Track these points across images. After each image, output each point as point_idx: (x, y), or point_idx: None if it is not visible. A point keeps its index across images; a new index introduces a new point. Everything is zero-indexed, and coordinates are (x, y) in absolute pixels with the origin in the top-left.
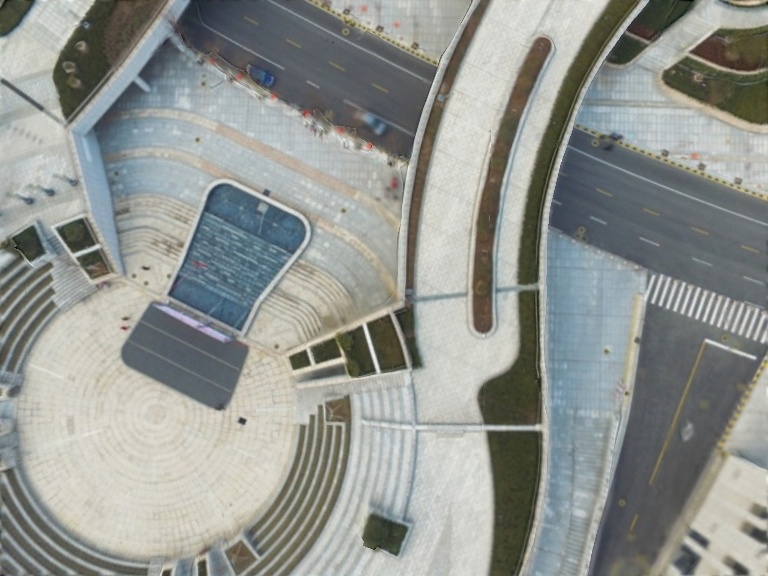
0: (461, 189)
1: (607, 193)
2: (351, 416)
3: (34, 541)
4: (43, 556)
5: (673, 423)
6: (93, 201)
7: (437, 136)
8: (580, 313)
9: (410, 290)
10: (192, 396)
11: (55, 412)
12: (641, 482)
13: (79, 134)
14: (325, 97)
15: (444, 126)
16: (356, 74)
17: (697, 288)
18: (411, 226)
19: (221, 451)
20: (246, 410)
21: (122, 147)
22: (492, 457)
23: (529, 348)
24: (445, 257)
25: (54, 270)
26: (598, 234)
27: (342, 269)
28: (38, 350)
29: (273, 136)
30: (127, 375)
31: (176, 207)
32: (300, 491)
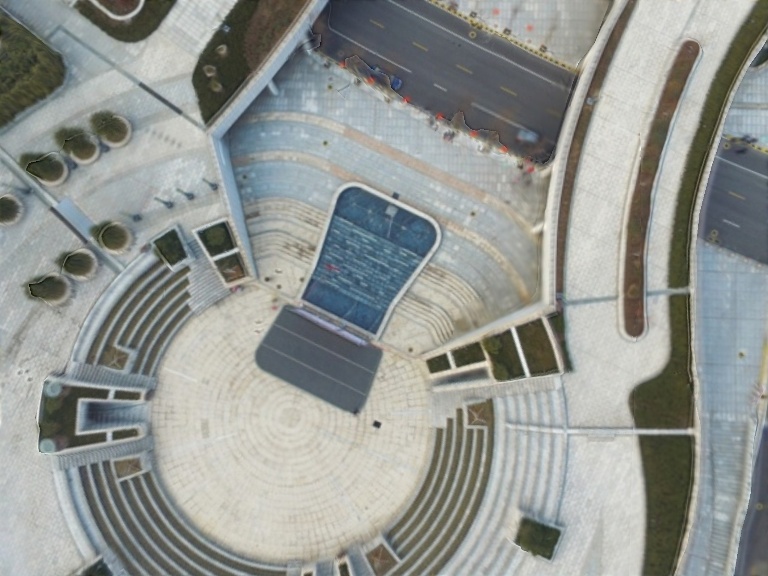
0: (610, 193)
1: (740, 196)
2: (494, 420)
3: (173, 544)
4: (183, 559)
5: None
6: (232, 205)
7: (585, 139)
8: (714, 316)
9: (560, 294)
10: (327, 399)
11: (189, 415)
12: None
13: (217, 138)
14: (453, 100)
15: (592, 129)
16: (484, 77)
17: None
18: (560, 230)
19: (356, 454)
20: (381, 413)
21: (250, 150)
22: (644, 461)
23: (681, 352)
24: (594, 261)
25: (191, 274)
26: (731, 237)
27: (472, 272)
28: (172, 353)
29: (401, 139)
30: (261, 378)
31: (306, 210)
32: (440, 494)
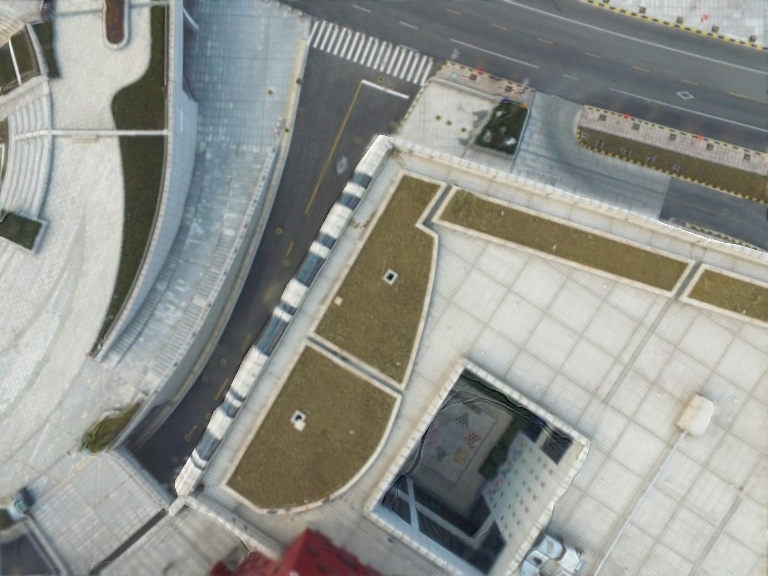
0: None
1: None
2: (8, 136)
3: None
4: None
5: (329, 157)
6: None
7: None
8: (247, 57)
9: (48, 5)
10: None
11: None
12: (298, 212)
13: None
14: None
15: None
16: None
17: (356, 33)
18: None
19: None
20: None
21: None
22: (123, 160)
23: (158, 58)
24: None
25: None
26: None
27: None
28: None
29: None
30: None
31: None
32: None
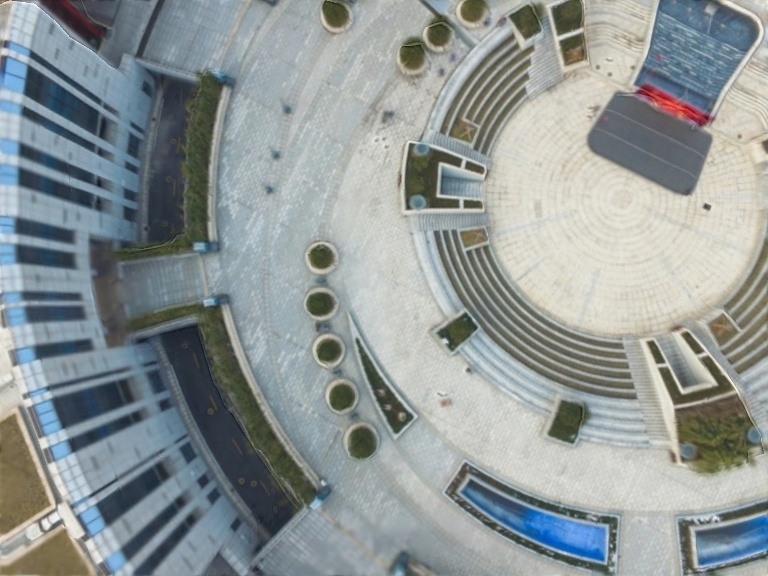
0: None
1: None
2: None
3: (516, 313)
4: (527, 326)
5: None
6: None
7: None
8: None
9: None
10: (659, 182)
11: (523, 196)
12: None
13: None
14: None
15: None
16: None
17: None
18: None
19: (687, 235)
20: (711, 196)
21: None
22: None
23: None
24: None
25: (534, 54)
26: None
27: None
28: (505, 137)
29: None
30: (593, 162)
31: (630, 6)
32: None
